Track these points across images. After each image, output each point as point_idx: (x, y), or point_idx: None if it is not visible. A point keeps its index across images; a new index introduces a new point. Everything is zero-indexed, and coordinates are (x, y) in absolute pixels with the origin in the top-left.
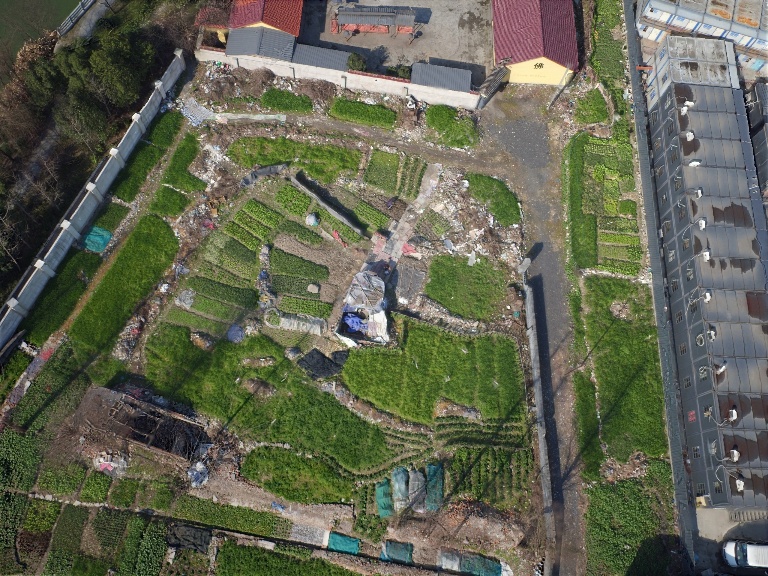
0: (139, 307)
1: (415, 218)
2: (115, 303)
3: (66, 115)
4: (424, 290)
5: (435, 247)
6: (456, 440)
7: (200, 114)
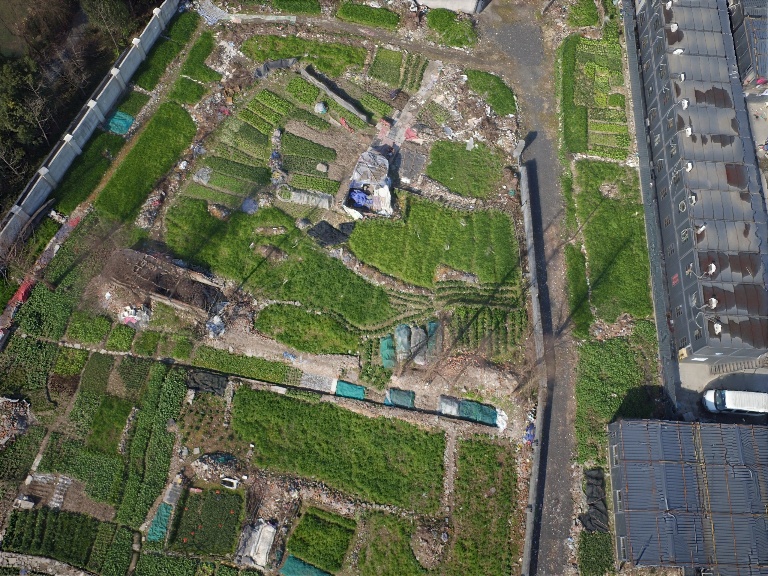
0: (160, 182)
1: (417, 108)
2: (137, 178)
3: (93, 4)
4: (425, 171)
5: (436, 133)
6: (455, 301)
7: (216, 14)
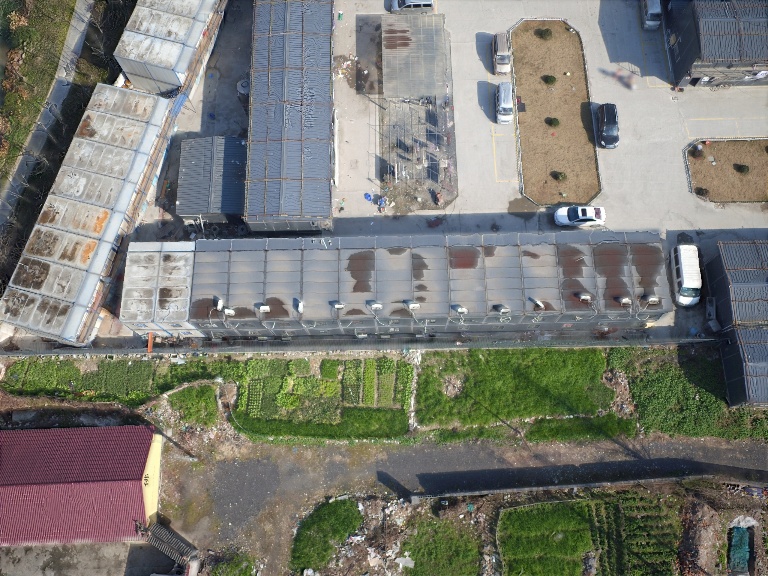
0: None
1: None
2: None
3: None
4: None
5: None
6: None
7: None
